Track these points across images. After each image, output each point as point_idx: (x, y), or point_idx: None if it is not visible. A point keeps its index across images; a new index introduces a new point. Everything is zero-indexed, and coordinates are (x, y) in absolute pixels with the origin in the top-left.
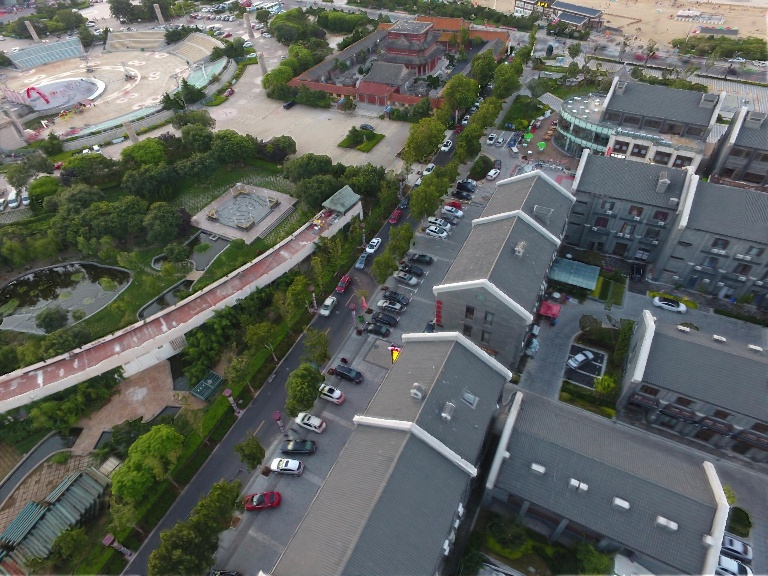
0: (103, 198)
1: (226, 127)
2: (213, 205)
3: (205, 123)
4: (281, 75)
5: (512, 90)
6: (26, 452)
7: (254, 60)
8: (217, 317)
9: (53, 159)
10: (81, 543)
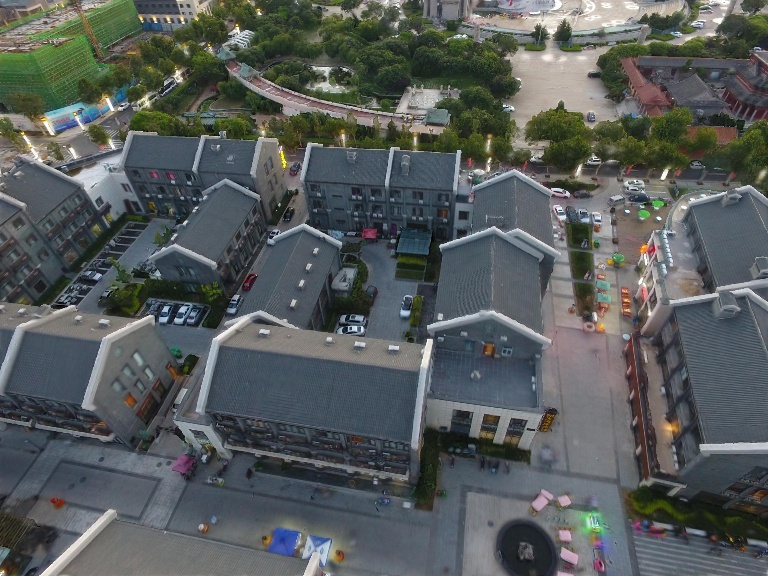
0: (408, 55)
1: (535, 64)
2: (422, 87)
3: (505, 47)
4: (629, 51)
5: (738, 165)
6: (242, 108)
7: (668, 37)
8: (316, 114)
9: (445, 32)
10: None
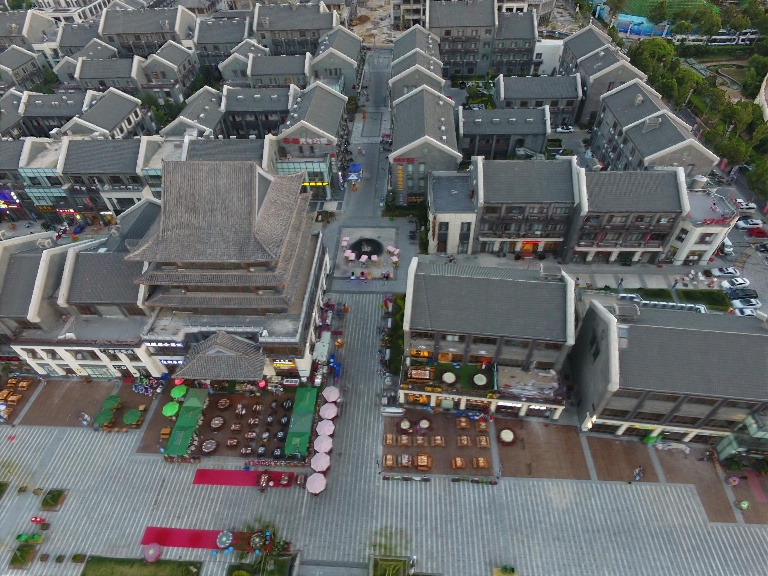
0: None
1: None
2: None
3: None
4: None
5: None
6: None
7: None
8: None
9: None
10: (672, 64)
